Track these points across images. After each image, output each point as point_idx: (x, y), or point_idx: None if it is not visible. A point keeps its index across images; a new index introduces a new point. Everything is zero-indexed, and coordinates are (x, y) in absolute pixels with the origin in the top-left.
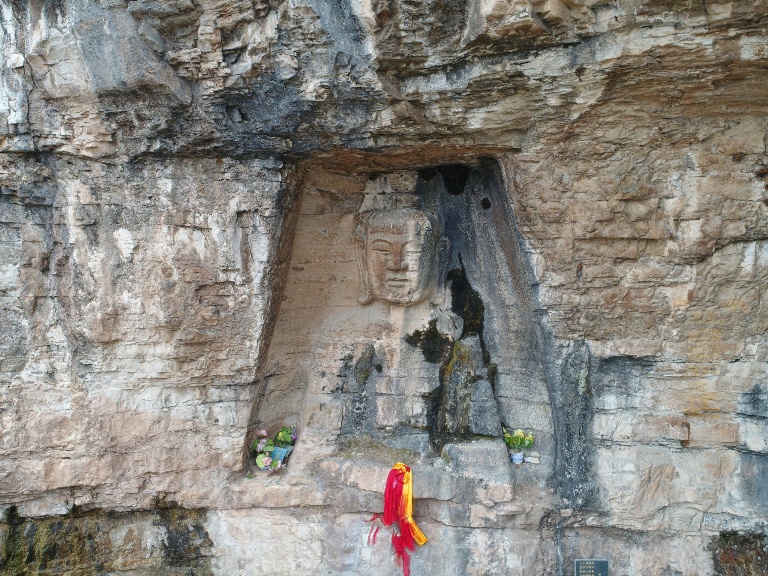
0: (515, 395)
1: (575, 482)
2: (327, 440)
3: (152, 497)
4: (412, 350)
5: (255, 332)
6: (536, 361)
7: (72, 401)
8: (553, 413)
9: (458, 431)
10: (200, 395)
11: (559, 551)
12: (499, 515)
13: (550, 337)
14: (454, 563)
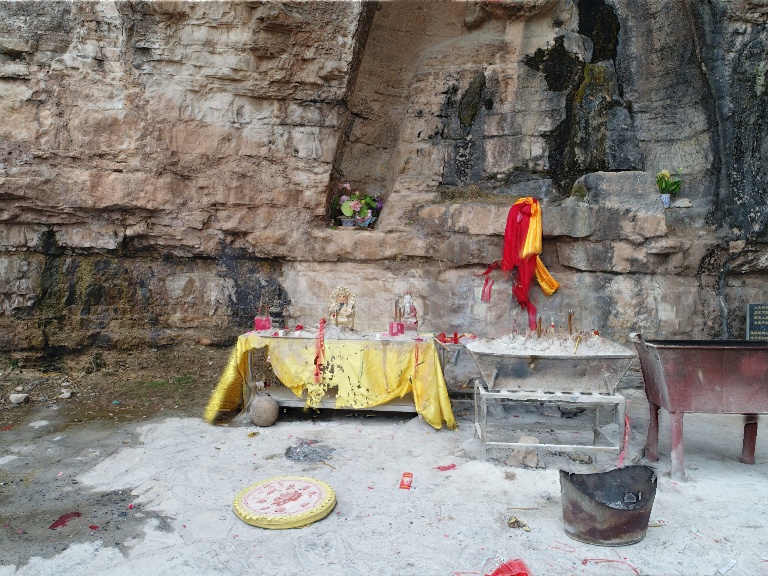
0: (654, 137)
1: (750, 205)
2: (427, 185)
3: (218, 240)
4: (532, 75)
5: (350, 23)
6: (687, 82)
7: (125, 99)
8: (715, 132)
9: (592, 165)
10: (279, 111)
11: (722, 302)
12: (650, 254)
13: (722, 20)
14: (593, 314)
